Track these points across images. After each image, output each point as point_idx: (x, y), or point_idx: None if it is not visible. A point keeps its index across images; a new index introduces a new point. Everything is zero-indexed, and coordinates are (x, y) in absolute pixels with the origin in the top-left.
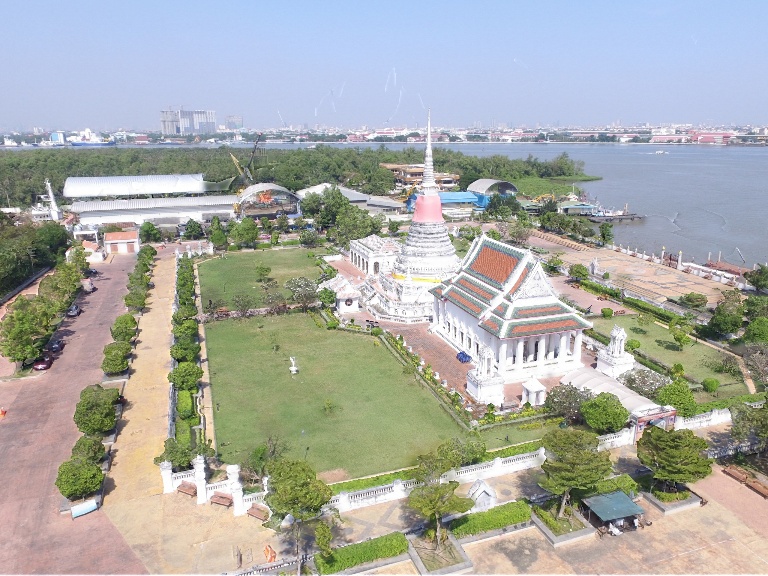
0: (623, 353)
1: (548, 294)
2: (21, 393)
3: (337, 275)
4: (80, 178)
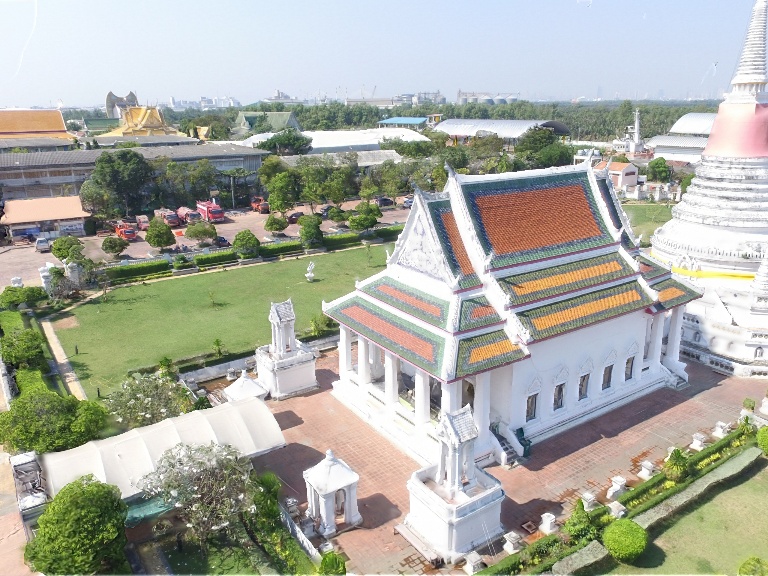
0: (451, 483)
1: (440, 275)
2: (244, 228)
3: None
4: (701, 113)
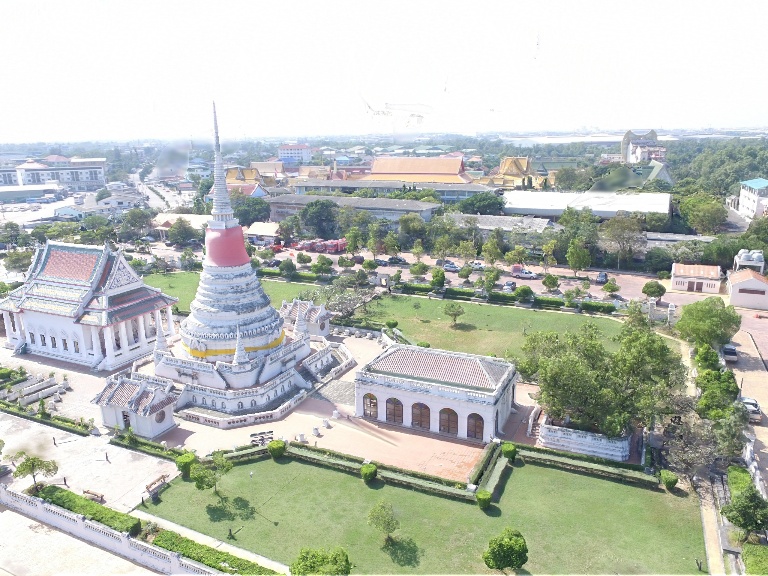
0: None
1: None
2: None
3: None
4: None
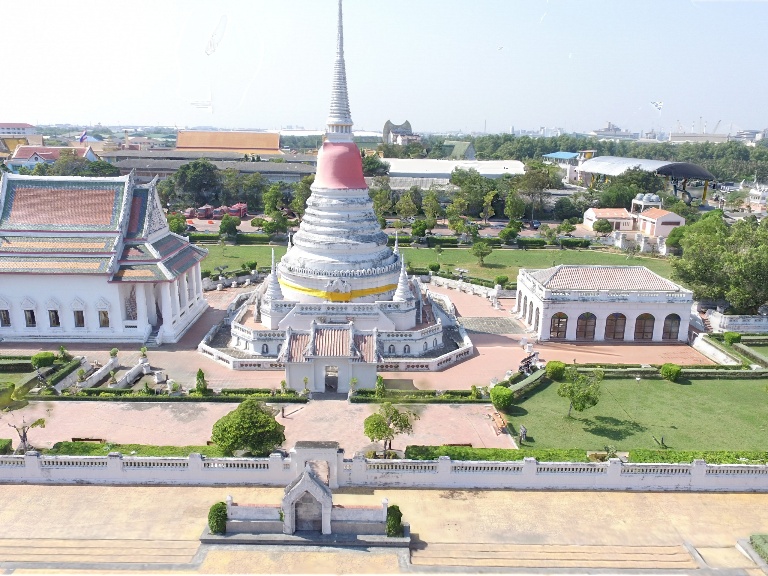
0: None
1: None
2: None
3: None
4: None
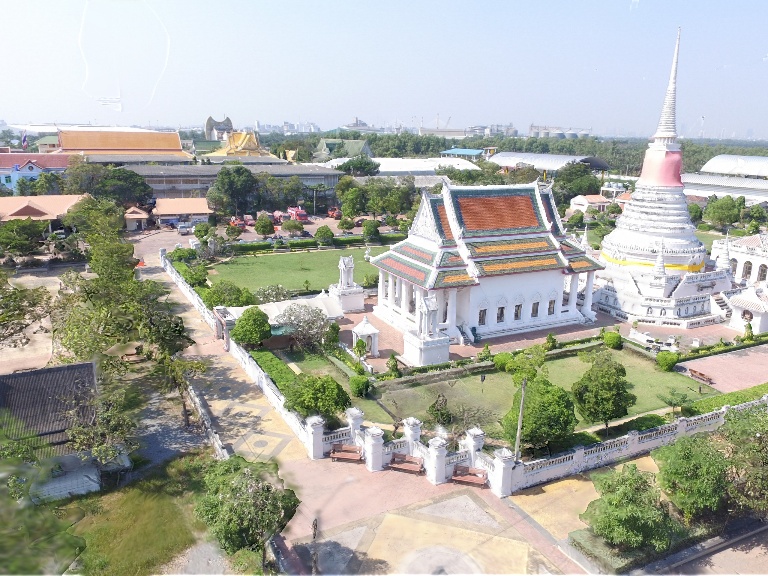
0: (424, 333)
1: (434, 239)
2: None
3: (581, 236)
4: None
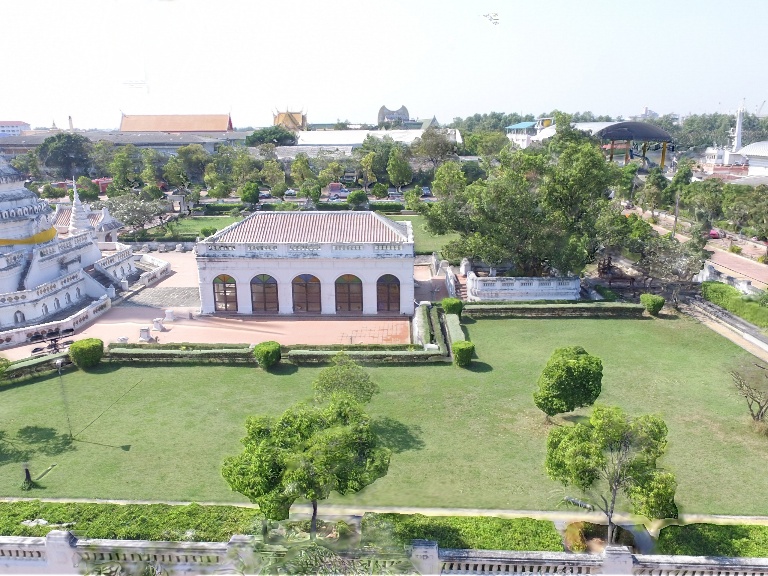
0: None
1: None
2: None
3: (106, 208)
4: None
